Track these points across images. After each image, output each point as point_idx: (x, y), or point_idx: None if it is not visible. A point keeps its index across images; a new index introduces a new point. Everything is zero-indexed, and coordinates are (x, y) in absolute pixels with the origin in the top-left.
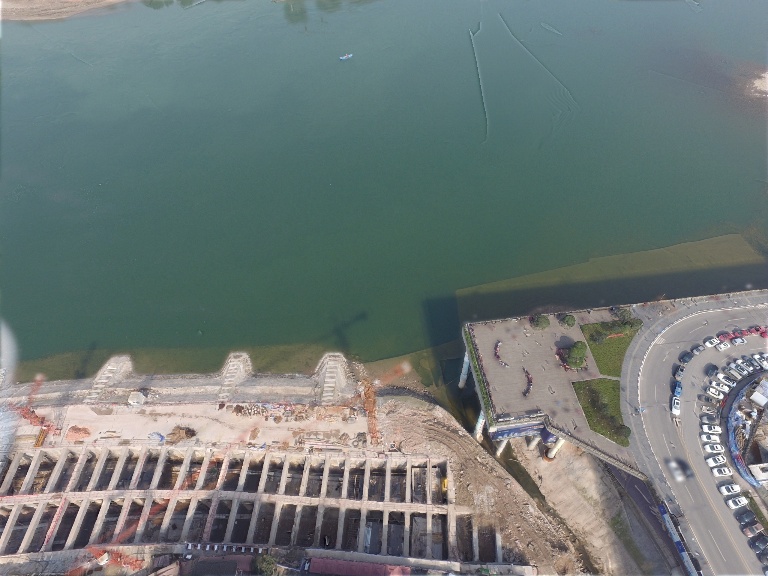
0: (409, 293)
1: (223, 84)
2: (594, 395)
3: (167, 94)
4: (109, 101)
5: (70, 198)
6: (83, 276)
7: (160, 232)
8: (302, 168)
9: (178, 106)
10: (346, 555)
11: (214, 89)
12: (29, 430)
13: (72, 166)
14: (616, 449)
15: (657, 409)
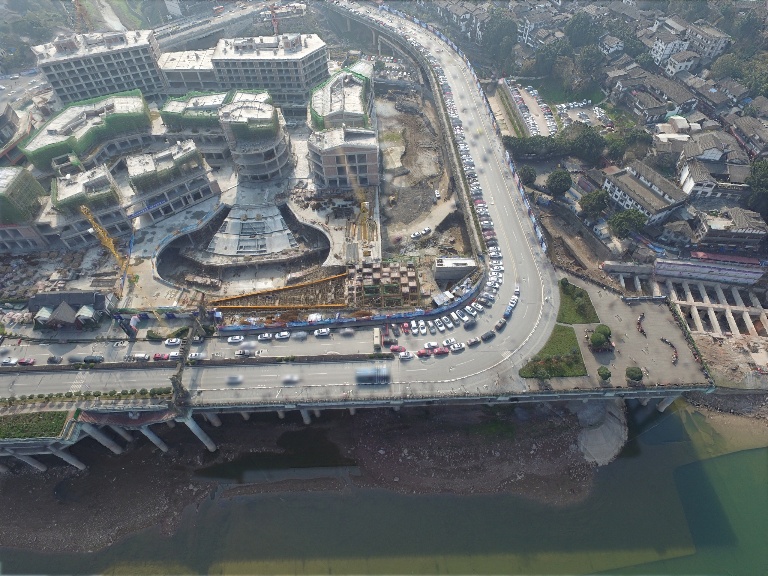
0: (767, 555)
1: None
2: (582, 311)
3: None
4: None
5: None
6: None
7: None
8: None
9: None
10: (735, 268)
11: None
12: None
13: None
14: (569, 279)
15: (529, 301)
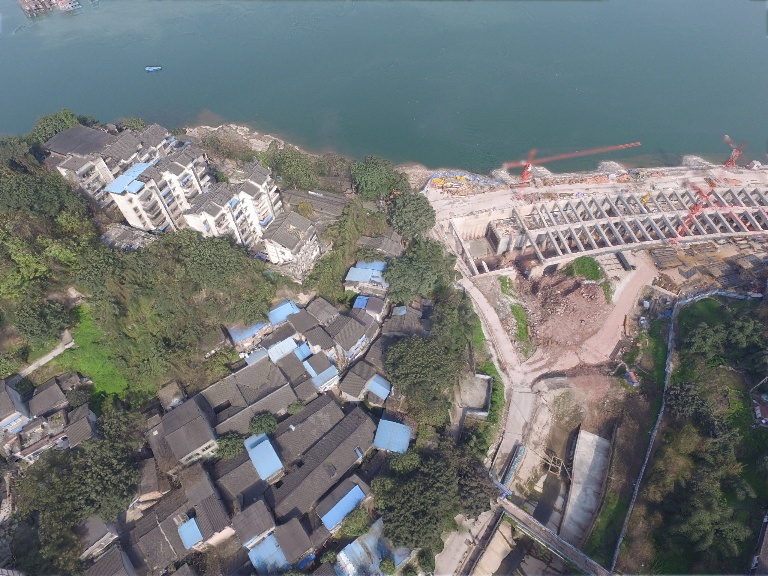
0: None
1: (572, 7)
2: None
3: (533, 13)
4: (505, 14)
5: (543, 73)
6: (608, 115)
7: (636, 92)
8: (703, 57)
9: (550, 21)
10: None
11: (569, 10)
12: (697, 180)
13: (521, 54)
14: None
15: None
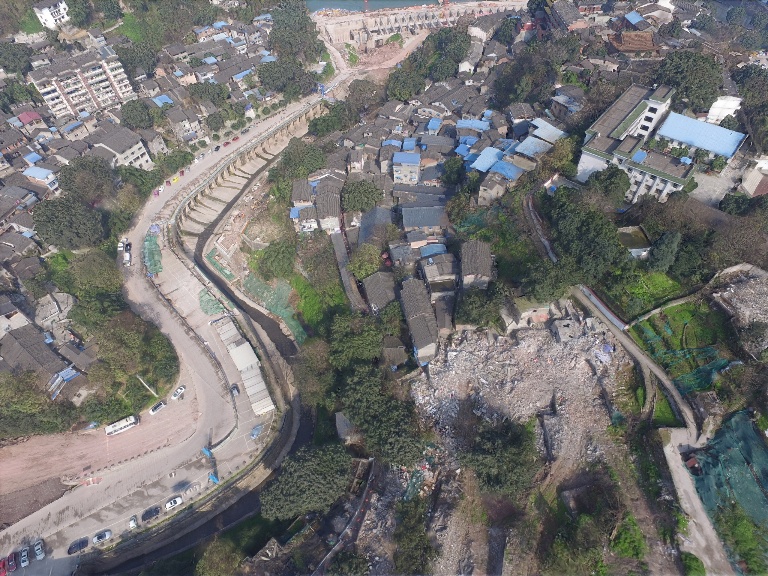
0: None
1: None
2: None
3: None
4: None
5: None
6: None
7: None
8: None
9: None
10: None
11: None
12: (473, 5)
13: None
14: None
15: None
